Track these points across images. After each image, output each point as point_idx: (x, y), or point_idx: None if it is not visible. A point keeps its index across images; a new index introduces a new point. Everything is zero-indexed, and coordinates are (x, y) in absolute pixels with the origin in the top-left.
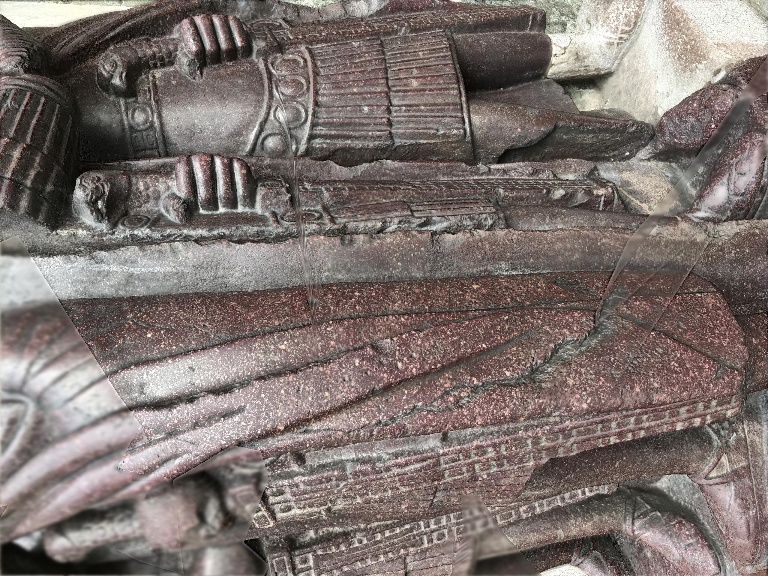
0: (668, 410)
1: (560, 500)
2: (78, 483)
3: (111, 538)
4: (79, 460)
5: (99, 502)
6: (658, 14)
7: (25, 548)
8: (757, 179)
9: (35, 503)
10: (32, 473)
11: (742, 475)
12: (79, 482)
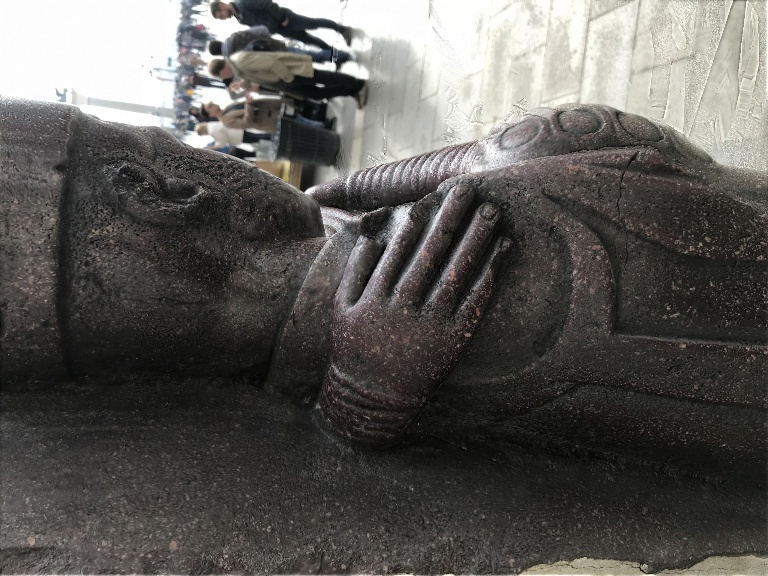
0: None
1: None
2: (459, 136)
3: (465, 132)
4: (458, 138)
5: (462, 135)
6: None
7: (456, 130)
8: None
9: (455, 134)
10: (454, 136)
11: None
12: (459, 136)
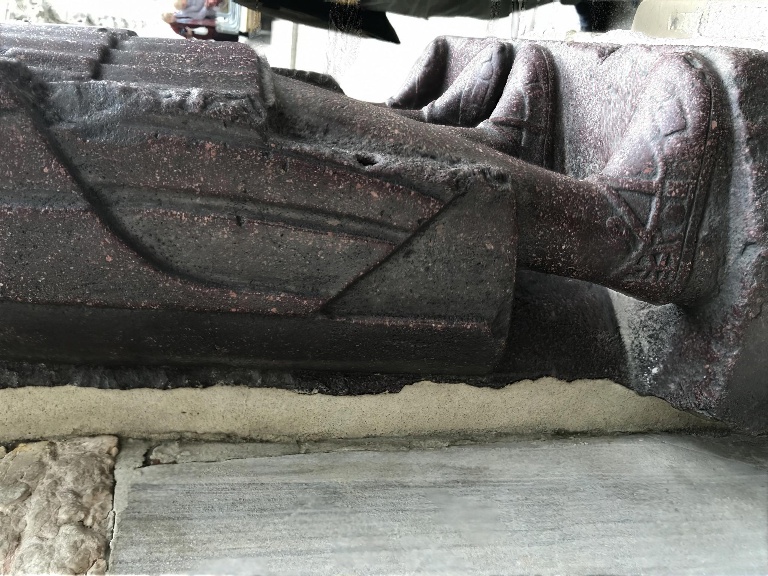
0: None
1: None
2: None
3: None
4: None
5: None
6: None
7: None
8: None
9: None
10: None
11: None
12: None
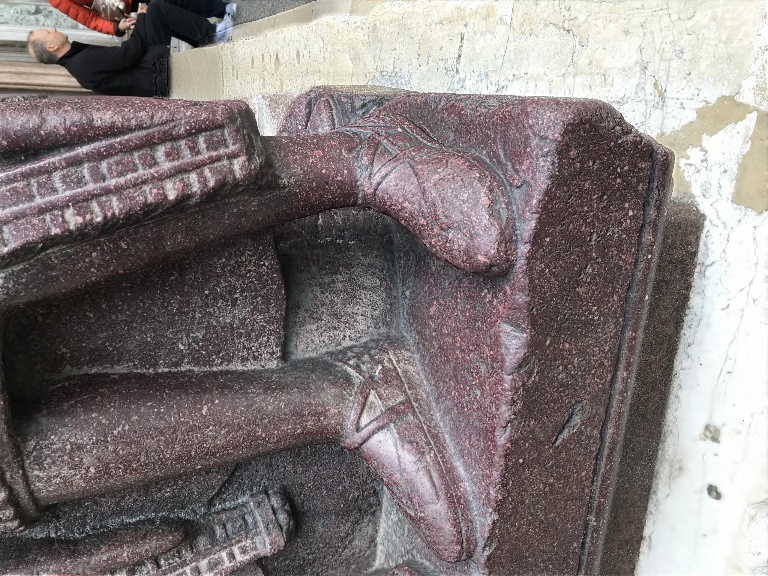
0: (135, 153)
1: (192, 574)
2: None
3: None
4: None
5: None
6: (267, 112)
7: None
8: (330, 126)
9: None
10: None
11: (402, 412)
12: None
